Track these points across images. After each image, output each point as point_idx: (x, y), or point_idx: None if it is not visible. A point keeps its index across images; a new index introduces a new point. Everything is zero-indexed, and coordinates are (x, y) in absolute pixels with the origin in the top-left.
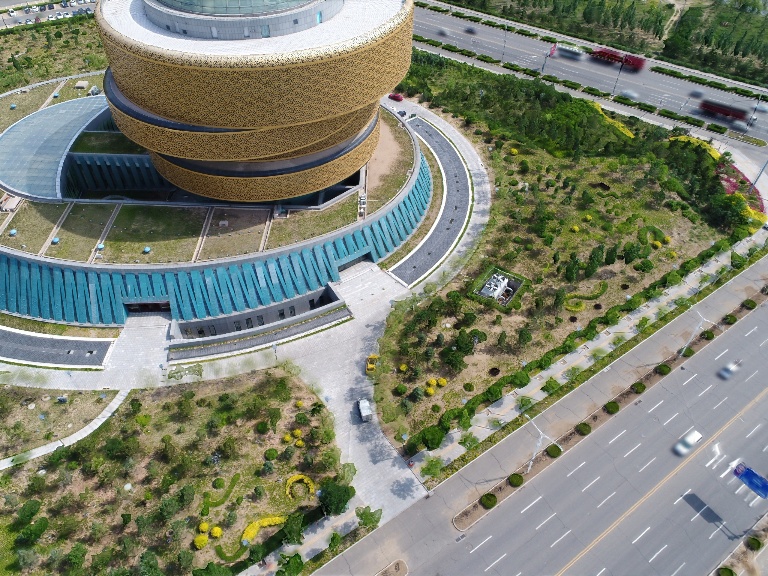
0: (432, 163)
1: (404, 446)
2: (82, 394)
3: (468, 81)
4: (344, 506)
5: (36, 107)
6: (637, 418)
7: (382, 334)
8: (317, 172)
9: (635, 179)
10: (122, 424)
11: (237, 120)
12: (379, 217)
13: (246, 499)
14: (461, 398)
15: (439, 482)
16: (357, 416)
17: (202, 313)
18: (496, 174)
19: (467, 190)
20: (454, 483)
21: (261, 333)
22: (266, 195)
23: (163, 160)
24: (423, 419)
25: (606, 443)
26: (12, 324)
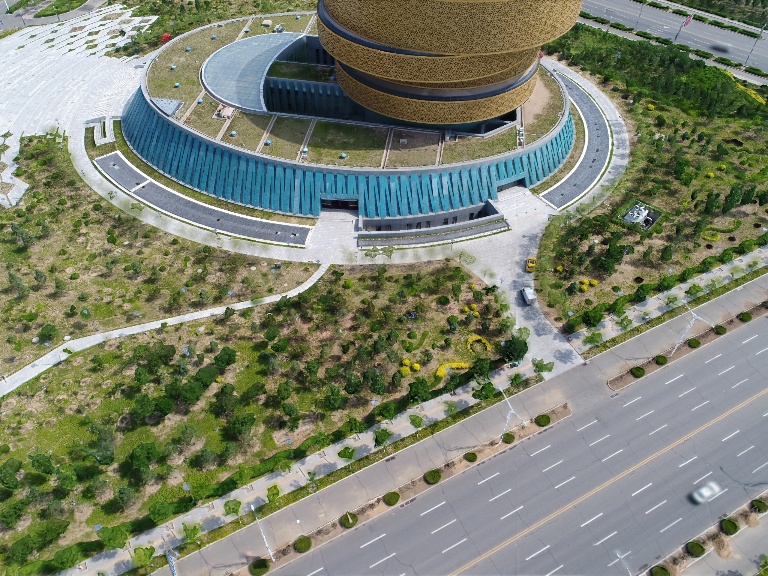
0: (573, 112)
1: (564, 325)
2: (292, 264)
3: (602, 45)
4: (522, 356)
5: (232, 39)
6: (767, 327)
7: (537, 243)
8: (489, 102)
9: (767, 138)
10: (327, 288)
11: (440, 46)
12: (536, 148)
13: (436, 348)
14: (610, 297)
15: (594, 355)
16: (521, 301)
17: (383, 213)
18: (634, 125)
19: (607, 136)
20: (607, 357)
21: (433, 233)
22: (444, 119)
23: (358, 83)
24: (578, 309)
25: (740, 343)
26: (228, 208)
